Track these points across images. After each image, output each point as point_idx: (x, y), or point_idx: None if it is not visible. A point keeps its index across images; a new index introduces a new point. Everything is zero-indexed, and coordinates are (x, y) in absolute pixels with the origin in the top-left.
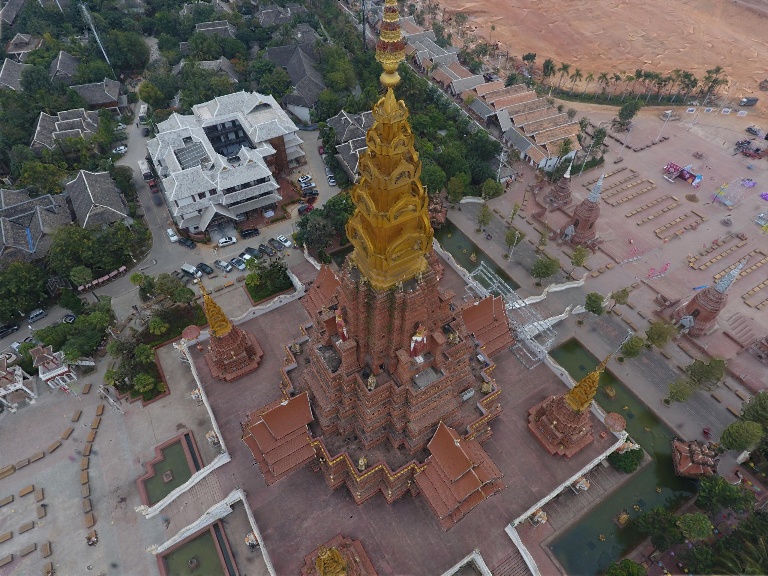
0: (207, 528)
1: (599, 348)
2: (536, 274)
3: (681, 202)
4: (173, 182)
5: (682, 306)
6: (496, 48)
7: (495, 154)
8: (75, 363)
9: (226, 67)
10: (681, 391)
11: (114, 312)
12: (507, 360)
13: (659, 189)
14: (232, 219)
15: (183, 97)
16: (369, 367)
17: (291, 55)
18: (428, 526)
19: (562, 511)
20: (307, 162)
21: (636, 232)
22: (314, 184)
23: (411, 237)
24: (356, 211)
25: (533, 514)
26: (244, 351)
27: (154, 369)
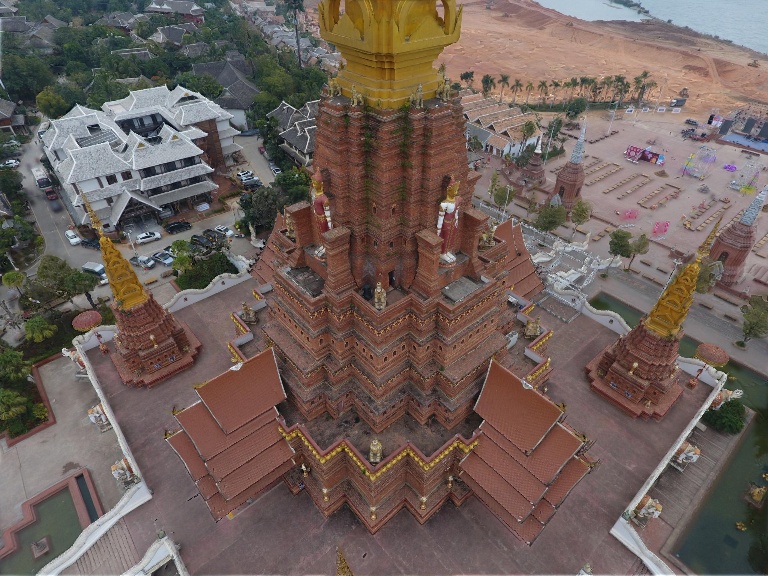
0: None
1: (636, 299)
2: (540, 227)
3: (652, 178)
4: (71, 162)
5: None
6: None
7: None
8: None
9: None
10: (763, 320)
11: None
12: (536, 316)
13: (626, 170)
14: (154, 210)
15: (92, 102)
16: (370, 286)
17: (221, 71)
18: (492, 548)
19: (671, 498)
20: (247, 161)
21: (619, 205)
22: (257, 177)
23: None
24: None
25: (638, 505)
26: (171, 337)
27: (31, 391)
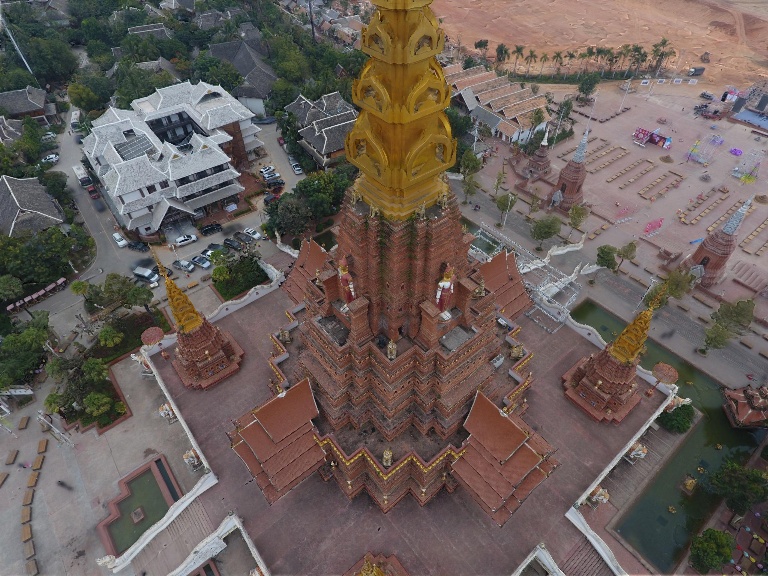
0: (196, 572)
1: (617, 306)
2: (537, 236)
3: (657, 164)
4: (115, 175)
5: (687, 258)
6: (446, 40)
7: (467, 129)
8: (6, 393)
9: (166, 67)
10: (720, 335)
11: (54, 330)
12: (525, 327)
13: (633, 154)
14: (189, 214)
15: (120, 96)
16: (384, 334)
17: (237, 51)
18: (474, 526)
19: (621, 486)
20: (267, 154)
21: (620, 195)
22: (278, 174)
23: (434, 139)
24: (356, 124)
25: (591, 493)
26: (221, 350)
27: (109, 388)
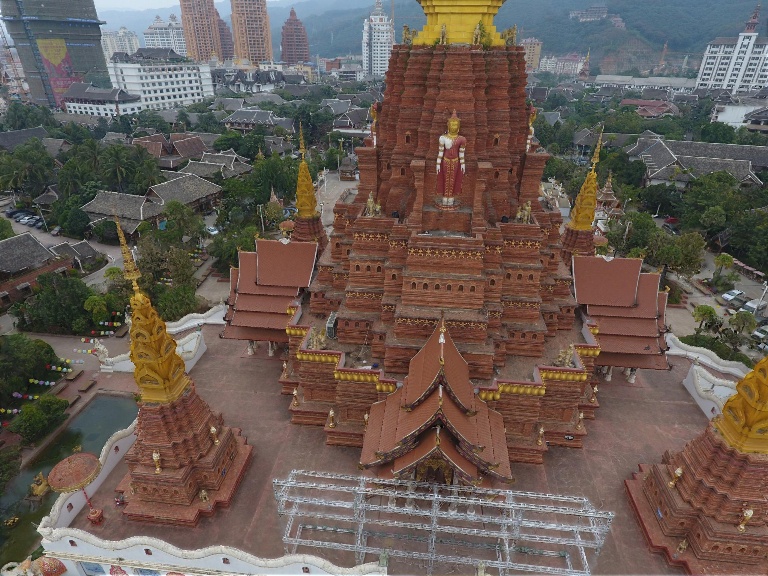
0: None
1: None
2: None
3: None
4: None
5: None
6: None
7: None
8: None
9: None
10: None
11: None
12: None
13: None
14: None
15: None
16: None
17: None
18: None
19: None
20: None
21: None
22: None
23: None
24: None
25: None
26: None
27: None
